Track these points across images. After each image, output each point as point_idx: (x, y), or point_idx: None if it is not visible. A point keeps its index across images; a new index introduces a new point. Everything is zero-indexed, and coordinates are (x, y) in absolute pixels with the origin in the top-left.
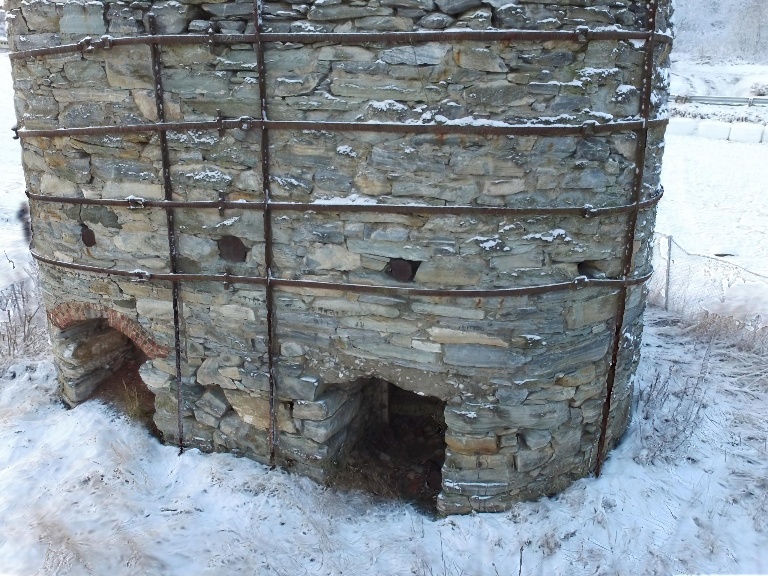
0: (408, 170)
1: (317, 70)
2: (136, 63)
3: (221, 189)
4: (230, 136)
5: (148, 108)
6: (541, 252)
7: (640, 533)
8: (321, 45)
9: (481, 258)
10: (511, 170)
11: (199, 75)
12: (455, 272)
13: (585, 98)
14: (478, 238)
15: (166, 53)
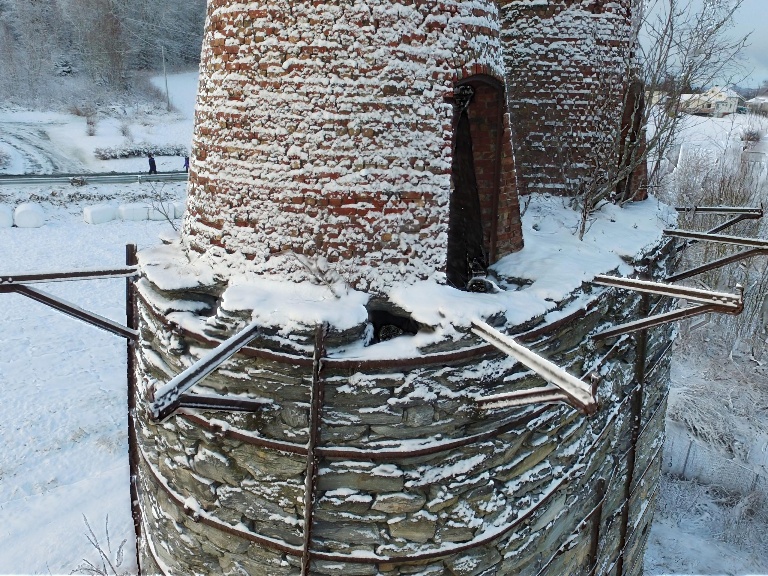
0: None
1: None
2: None
3: None
4: None
5: None
6: None
7: (648, 561)
8: None
9: None
10: None
11: None
12: None
13: None
14: None
15: None
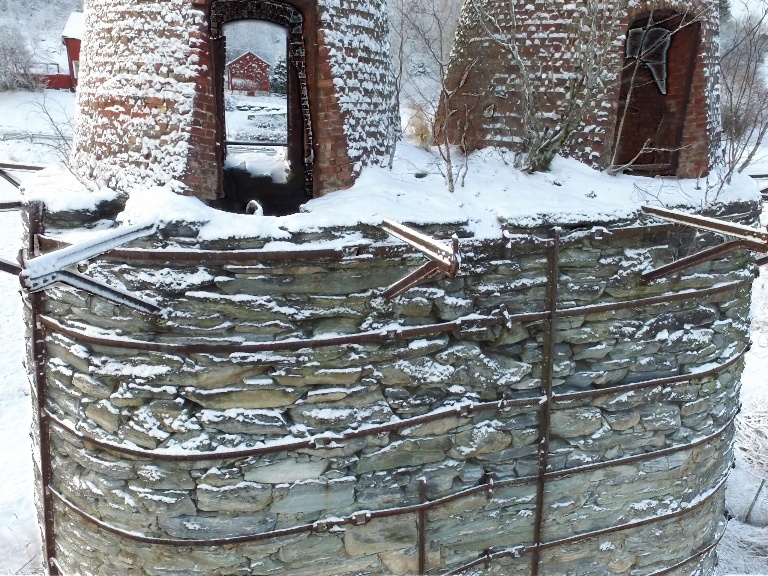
0: (655, 546)
1: (588, 490)
2: (392, 526)
3: None
4: (497, 565)
5: (401, 565)
6: None
7: None
8: (594, 470)
9: None
10: None
11: (471, 521)
12: None
13: None
14: (693, 574)
15: (434, 510)
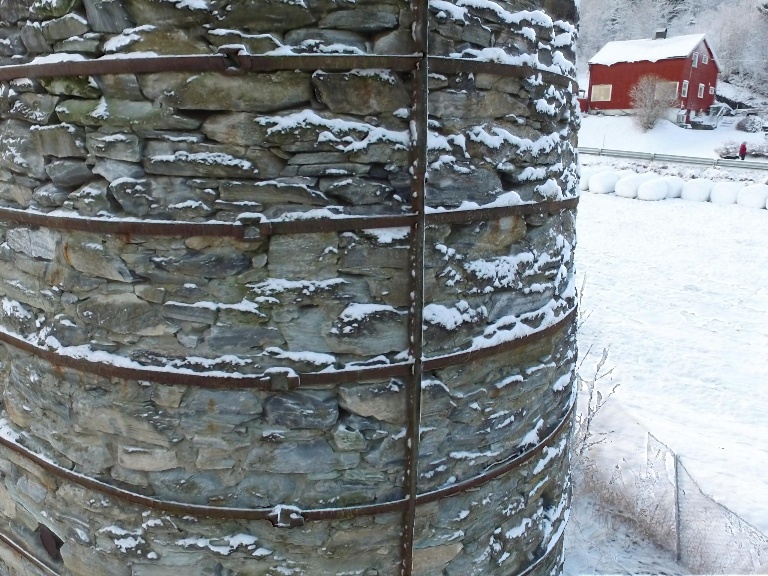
0: None
1: None
2: None
3: None
4: None
5: None
6: (212, 568)
7: None
8: None
9: (120, 560)
10: (150, 435)
11: None
12: (93, 570)
13: (268, 330)
14: (113, 529)
15: None
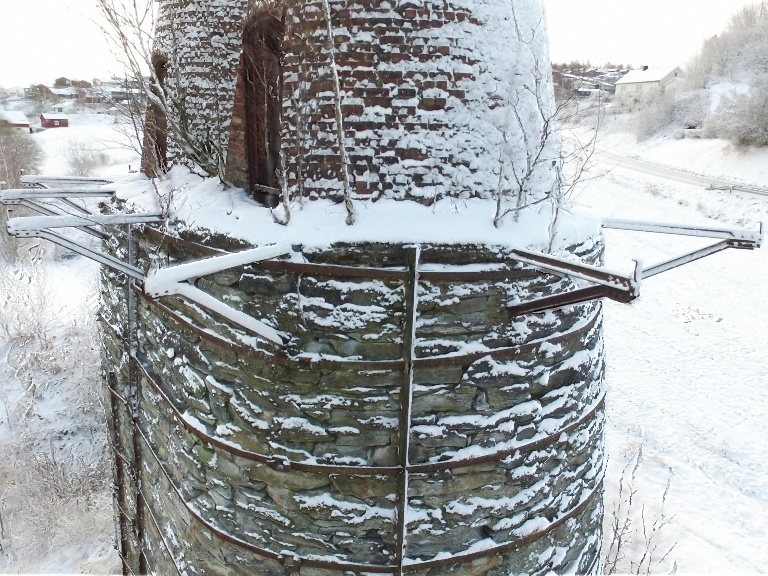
0: None
1: None
2: None
3: (133, 516)
4: None
5: None
6: None
7: None
8: None
9: None
10: None
11: (126, 427)
12: None
13: None
14: None
15: None
